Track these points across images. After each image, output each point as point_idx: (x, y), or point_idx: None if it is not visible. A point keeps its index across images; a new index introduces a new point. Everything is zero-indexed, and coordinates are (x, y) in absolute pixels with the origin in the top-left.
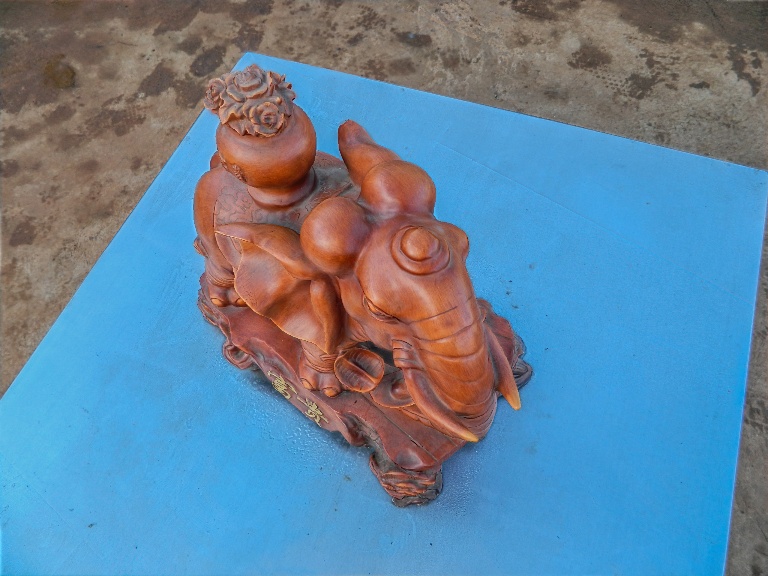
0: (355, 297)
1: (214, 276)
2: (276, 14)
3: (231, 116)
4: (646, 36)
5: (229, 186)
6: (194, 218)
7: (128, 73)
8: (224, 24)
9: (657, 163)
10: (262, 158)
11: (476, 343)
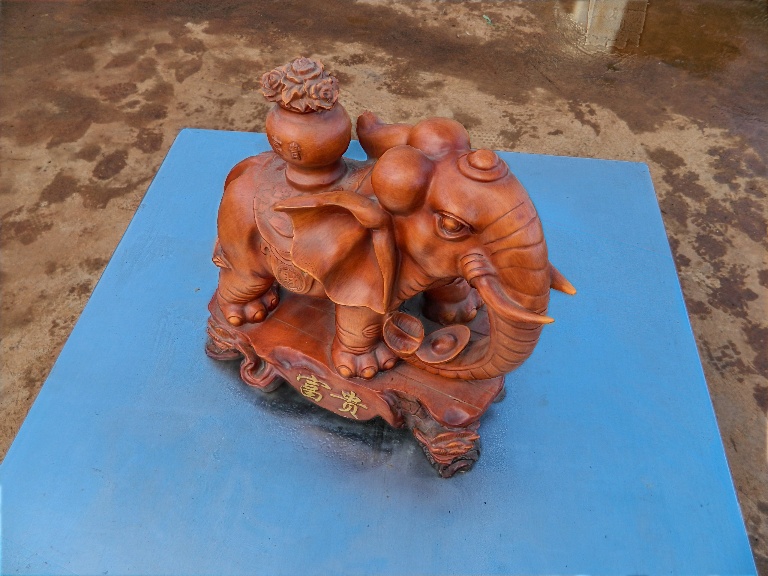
0: (425, 227)
1: (235, 290)
2: (172, 117)
3: (294, 95)
4: (503, 101)
5: (265, 182)
6: (222, 227)
7: (25, 185)
8: (121, 131)
9: (564, 168)
10: (318, 133)
11: (541, 233)
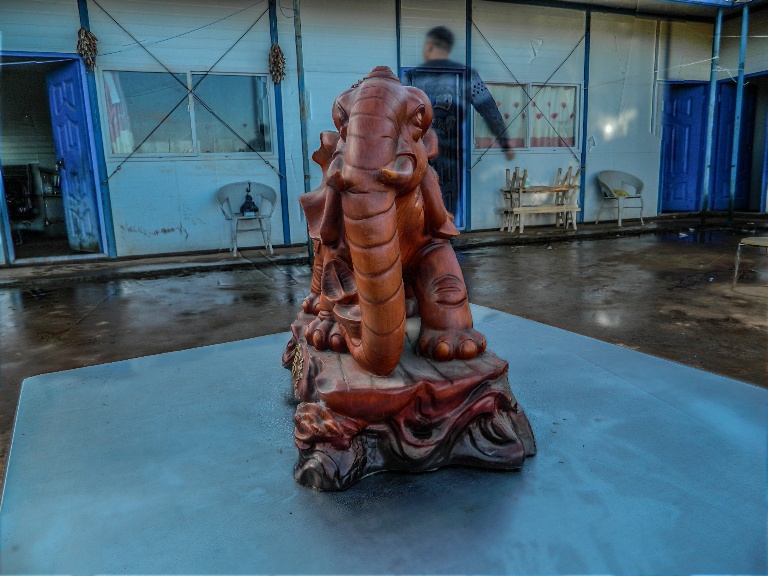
0: None
1: None
2: None
3: (353, 87)
4: None
5: None
6: None
7: None
8: None
9: None
10: None
11: (375, 109)
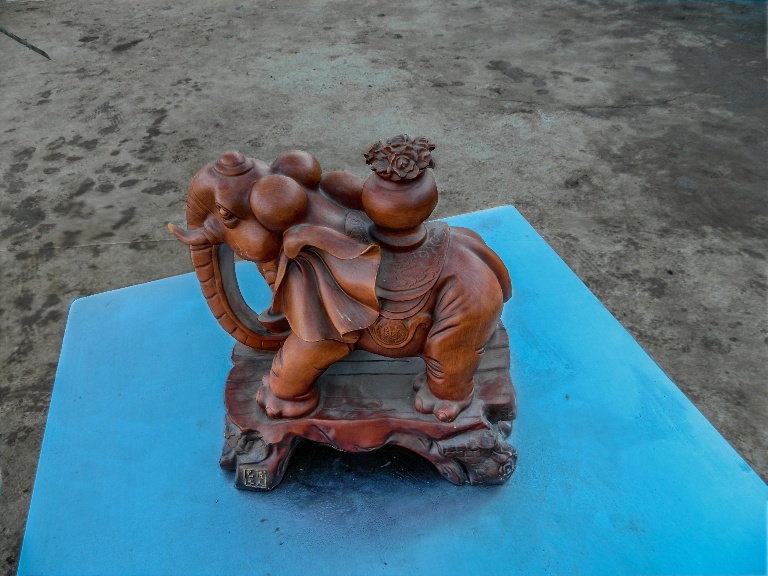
0: None
1: None
2: None
3: None
4: None
5: None
6: None
7: None
8: None
9: None
10: None
11: None
